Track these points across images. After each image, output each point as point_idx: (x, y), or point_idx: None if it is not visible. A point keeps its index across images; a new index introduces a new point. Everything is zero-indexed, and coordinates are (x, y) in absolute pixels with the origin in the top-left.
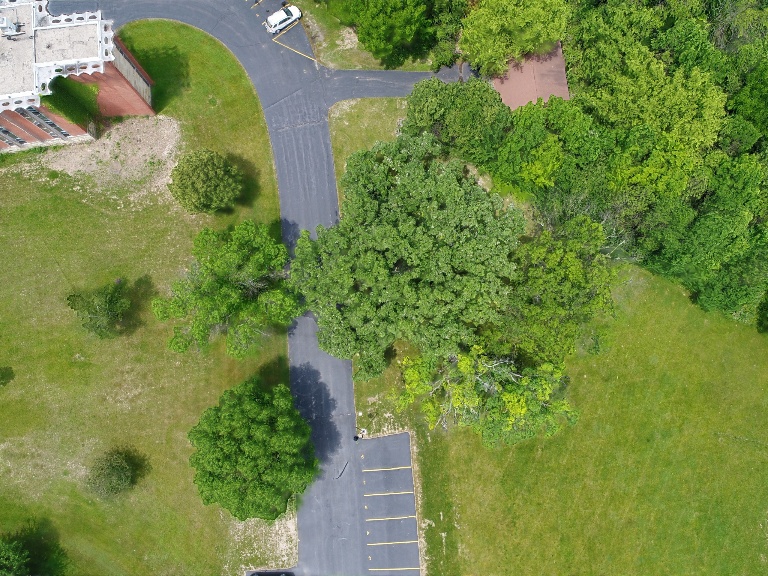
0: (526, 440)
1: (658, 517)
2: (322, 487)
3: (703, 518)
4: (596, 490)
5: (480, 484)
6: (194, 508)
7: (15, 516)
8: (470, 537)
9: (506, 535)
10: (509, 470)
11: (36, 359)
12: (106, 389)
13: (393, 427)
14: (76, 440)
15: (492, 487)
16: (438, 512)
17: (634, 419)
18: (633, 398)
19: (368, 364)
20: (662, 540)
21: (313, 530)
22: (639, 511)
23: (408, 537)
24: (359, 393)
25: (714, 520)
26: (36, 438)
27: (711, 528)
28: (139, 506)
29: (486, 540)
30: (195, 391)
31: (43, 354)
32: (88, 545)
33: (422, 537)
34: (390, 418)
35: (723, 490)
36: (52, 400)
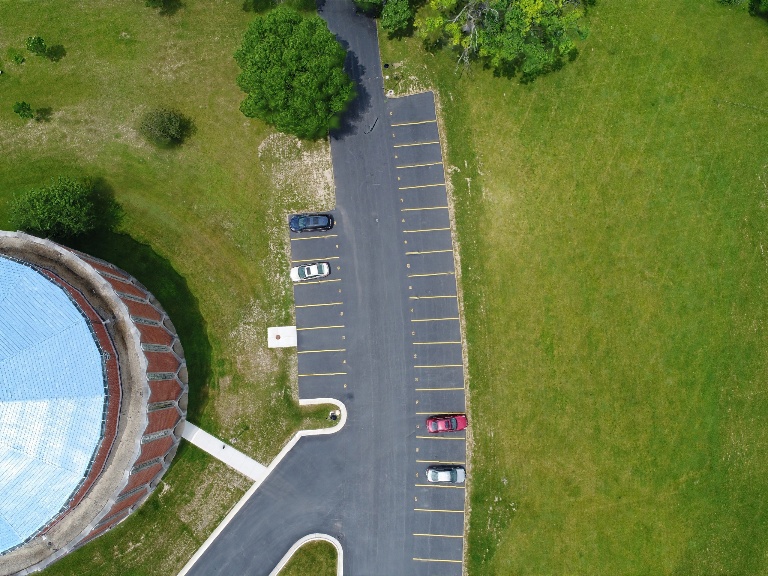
0: (540, 102)
1: (665, 169)
2: (355, 141)
3: (706, 171)
4: (607, 145)
5: (500, 137)
6: (238, 163)
7: (72, 177)
8: (493, 182)
9: (526, 181)
10: (526, 127)
11: (85, 38)
12: (151, 62)
13: (418, 87)
14: (126, 107)
15: (511, 140)
16: (463, 160)
17: (639, 86)
18: (637, 69)
19: (394, 10)
20: (669, 188)
21: (348, 178)
22: (647, 163)
23: (436, 180)
24: (385, 59)
25: (716, 173)
26: (89, 106)
27: (714, 179)
28: (187, 162)
29: (508, 185)
30: (234, 62)
31: (91, 33)
32: (141, 199)
33: (449, 180)
34: (415, 80)
35: (723, 148)
36: (102, 73)
